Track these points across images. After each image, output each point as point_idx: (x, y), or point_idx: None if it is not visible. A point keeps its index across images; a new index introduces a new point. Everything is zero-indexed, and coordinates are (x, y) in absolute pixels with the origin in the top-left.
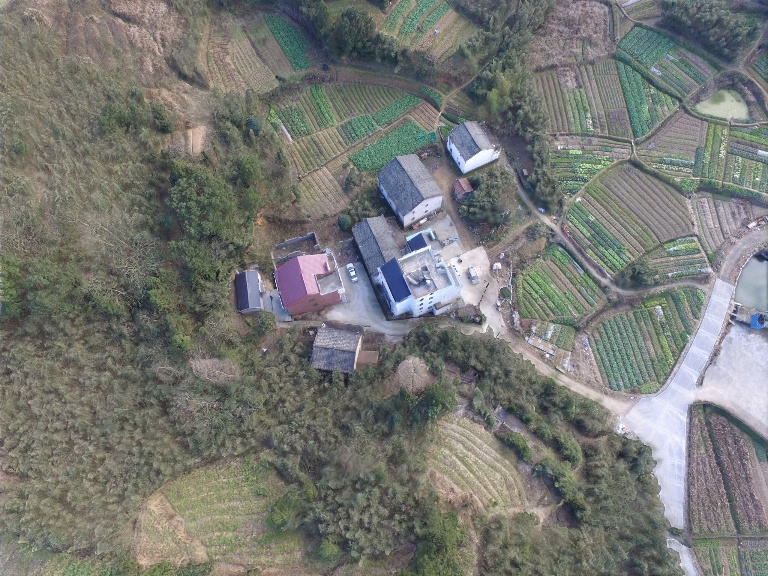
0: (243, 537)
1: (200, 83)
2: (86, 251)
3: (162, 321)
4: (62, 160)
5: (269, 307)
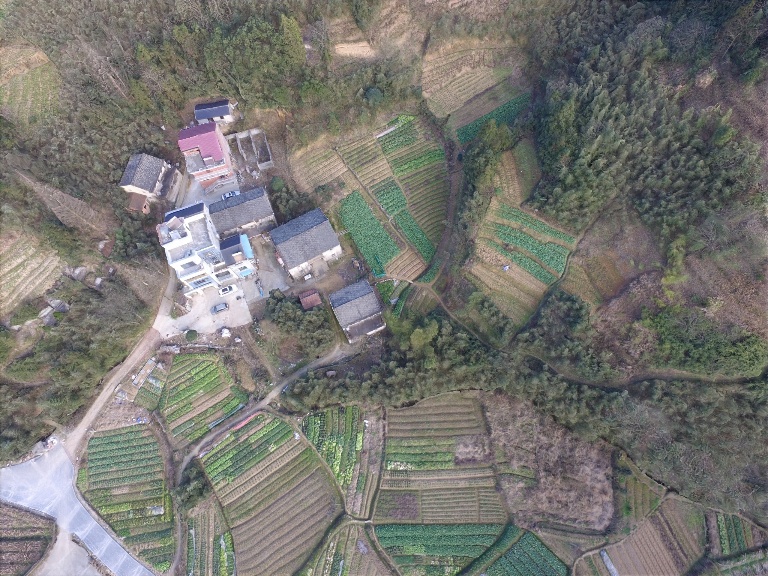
0: (1, 108)
1: None
2: None
3: (175, 44)
4: None
5: None
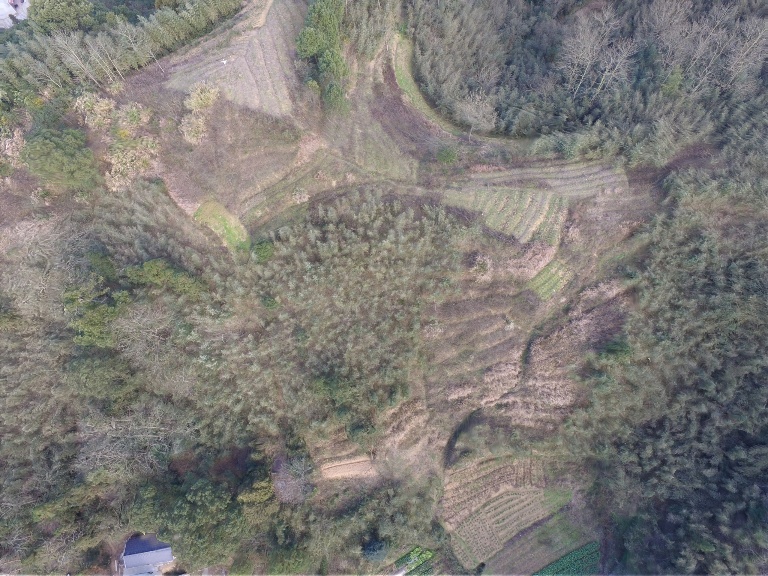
0: None
1: (451, 457)
2: (158, 388)
3: None
4: (264, 346)
5: (140, 570)
